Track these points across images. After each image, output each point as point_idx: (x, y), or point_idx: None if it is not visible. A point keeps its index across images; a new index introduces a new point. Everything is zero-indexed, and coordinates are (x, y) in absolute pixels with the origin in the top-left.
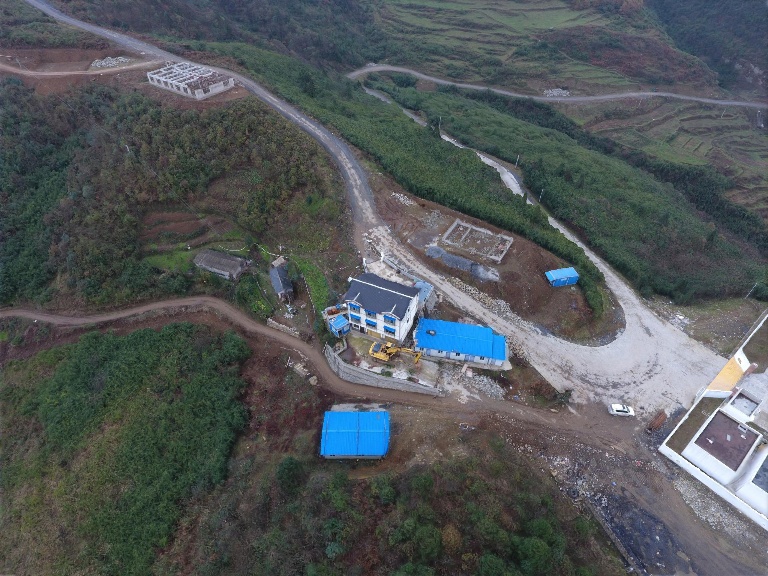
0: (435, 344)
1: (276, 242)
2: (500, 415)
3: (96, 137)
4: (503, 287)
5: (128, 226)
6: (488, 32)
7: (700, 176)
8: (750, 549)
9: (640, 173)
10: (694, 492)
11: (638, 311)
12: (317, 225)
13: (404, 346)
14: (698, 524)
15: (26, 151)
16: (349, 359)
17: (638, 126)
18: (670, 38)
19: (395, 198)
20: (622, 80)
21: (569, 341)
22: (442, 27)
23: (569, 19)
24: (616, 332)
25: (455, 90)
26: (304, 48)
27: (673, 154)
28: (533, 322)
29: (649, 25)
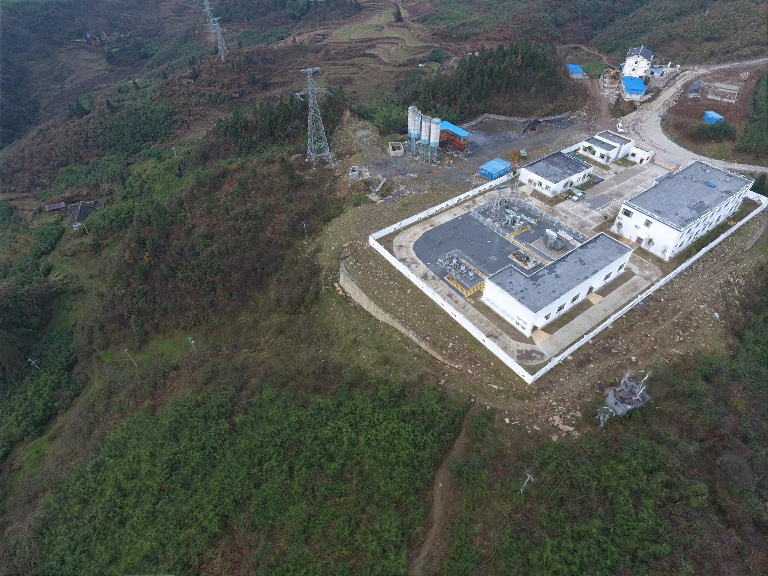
0: None
1: None
2: (599, 102)
3: (712, 7)
4: None
5: (661, 39)
6: None
7: None
8: None
9: None
10: (584, 136)
11: (718, 164)
12: None
13: None
14: None
15: (691, 7)
16: (608, 72)
17: None
18: None
19: None
20: None
21: (662, 125)
22: None
23: None
24: None
25: None
26: None
27: None
28: None
29: None
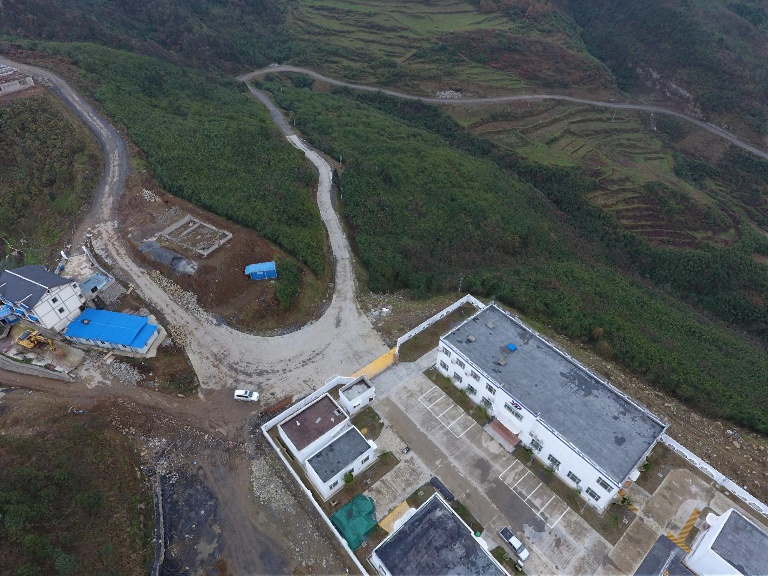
0: (82, 332)
1: (22, 236)
2: (122, 399)
3: None
4: (194, 280)
5: None
6: (392, 34)
7: (566, 177)
8: (283, 522)
9: (496, 174)
10: (265, 470)
11: (344, 304)
12: (59, 220)
13: (62, 335)
14: (249, 500)
15: None
16: (1, 347)
17: (522, 128)
18: (577, 42)
19: (142, 195)
20: (518, 83)
21: (243, 331)
22: (348, 29)
23: (473, 22)
24: (306, 323)
25: (347, 91)
26: (198, 48)
27: (546, 156)
28: (214, 313)
29: (556, 29)
